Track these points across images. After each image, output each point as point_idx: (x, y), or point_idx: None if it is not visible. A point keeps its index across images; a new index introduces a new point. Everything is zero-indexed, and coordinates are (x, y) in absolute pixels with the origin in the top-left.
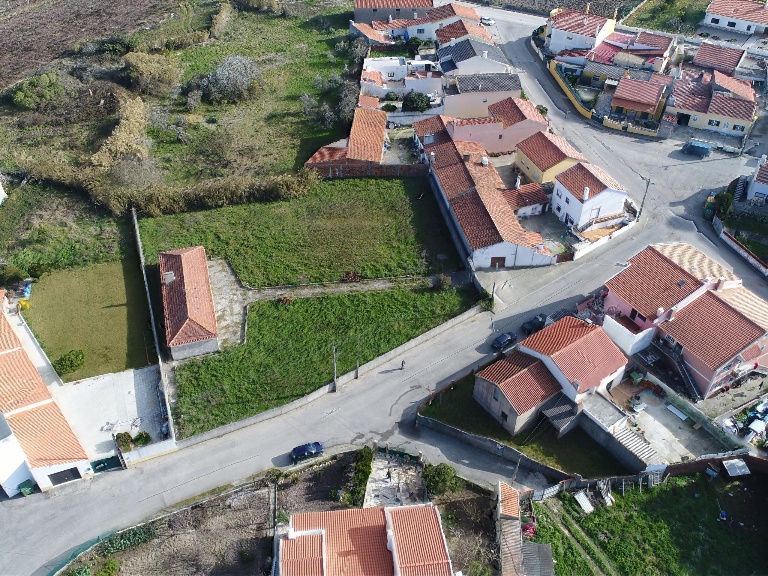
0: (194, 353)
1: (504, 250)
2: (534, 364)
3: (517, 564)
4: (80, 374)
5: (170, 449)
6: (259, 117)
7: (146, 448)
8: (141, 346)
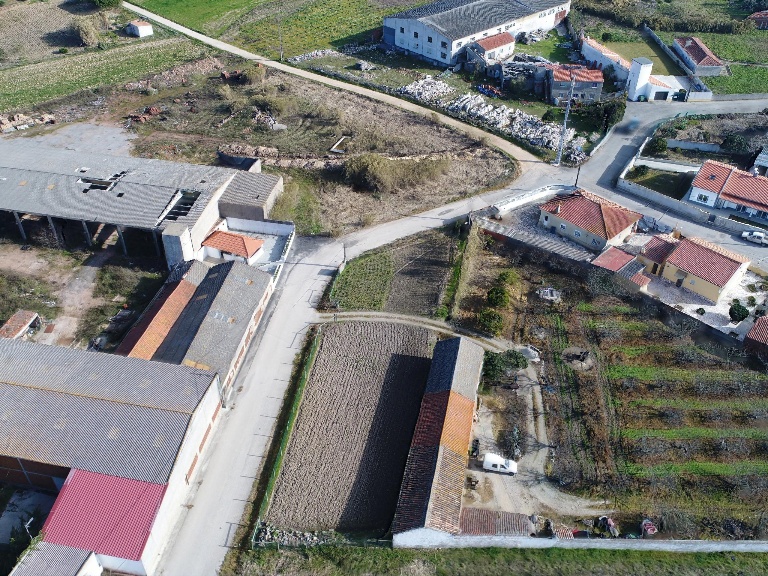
0: (706, 74)
1: None
2: None
3: None
4: None
5: (708, 99)
6: (698, 3)
7: (699, 93)
8: (674, 69)
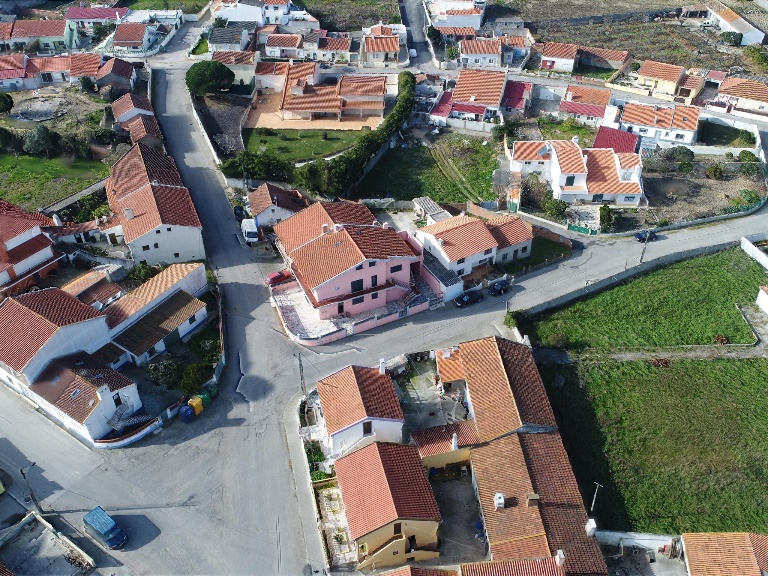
0: None
1: None
2: (491, 227)
3: None
4: None
5: None
6: None
7: (759, 234)
8: None
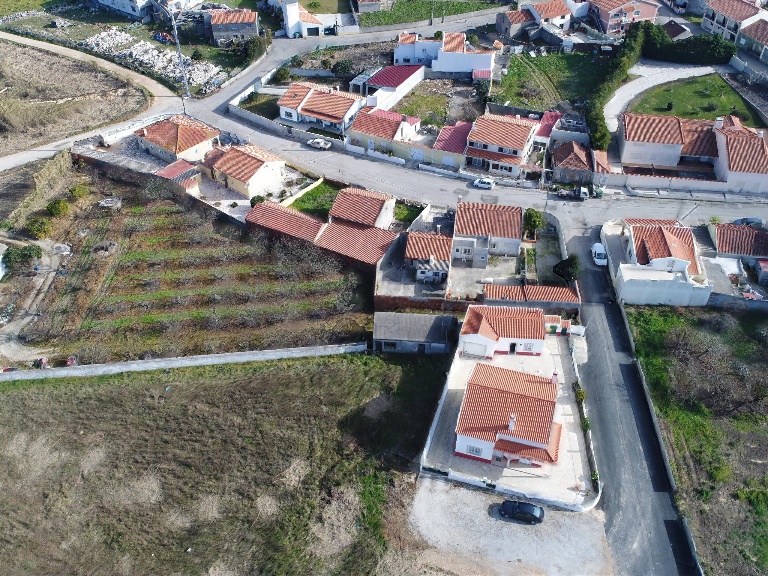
0: (369, 10)
1: None
2: (525, 9)
3: (495, 58)
4: (317, 13)
5: (356, 32)
6: None
7: (347, 27)
8: (344, 8)
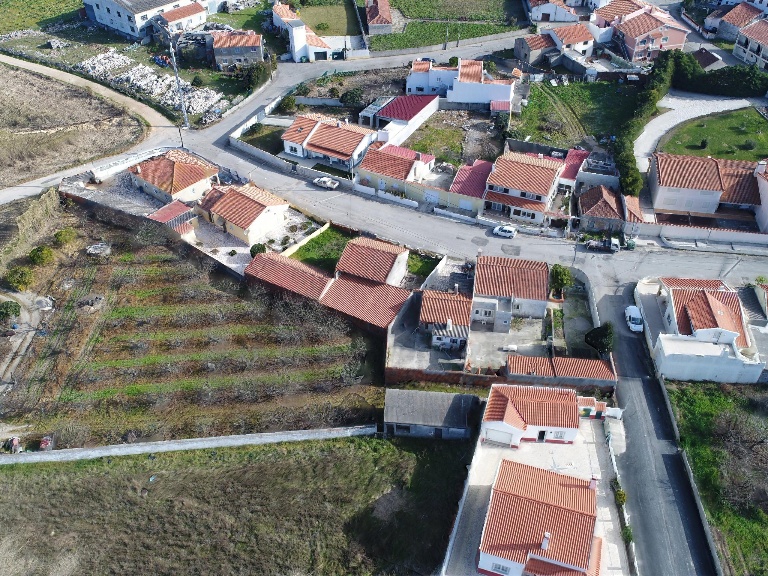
0: (379, 32)
1: (549, 9)
2: None
3: (514, 87)
4: (325, 35)
5: (366, 56)
6: None
7: (356, 51)
8: (354, 30)
